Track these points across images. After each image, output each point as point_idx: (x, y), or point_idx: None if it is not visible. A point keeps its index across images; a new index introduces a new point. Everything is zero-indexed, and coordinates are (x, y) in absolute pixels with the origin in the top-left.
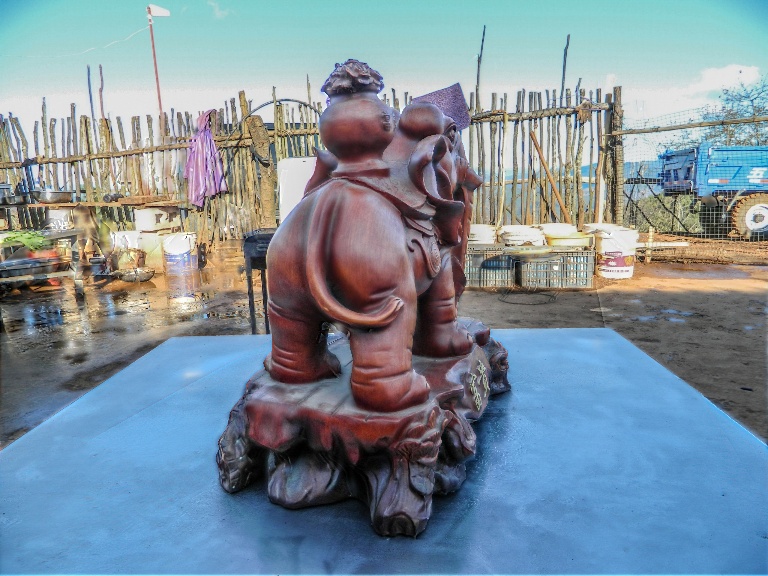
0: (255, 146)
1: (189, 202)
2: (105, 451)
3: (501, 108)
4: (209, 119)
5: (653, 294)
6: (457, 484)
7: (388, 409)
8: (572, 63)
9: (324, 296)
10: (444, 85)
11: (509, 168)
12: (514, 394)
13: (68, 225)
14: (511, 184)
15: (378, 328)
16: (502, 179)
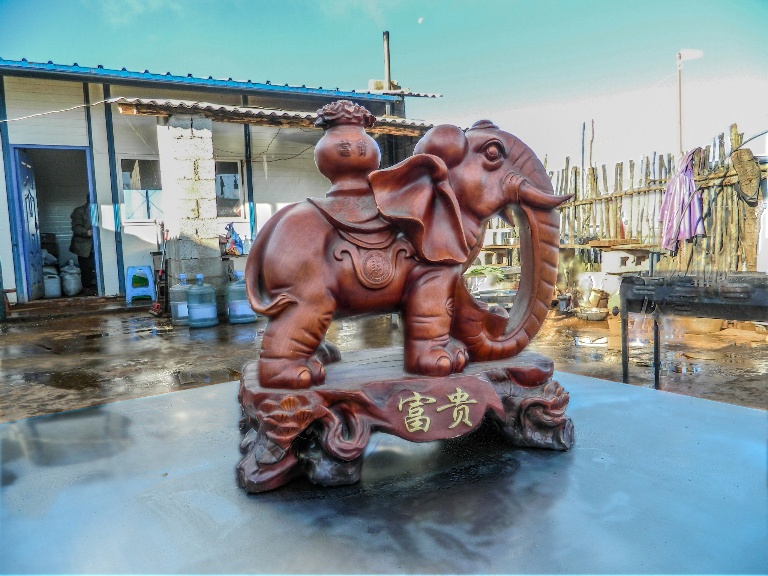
0: (740, 183)
1: (662, 246)
2: None
3: None
4: (692, 158)
5: None
6: (327, 479)
7: (263, 384)
8: None
9: (248, 287)
10: None
11: None
12: (559, 455)
13: None
14: None
15: (267, 317)
16: None
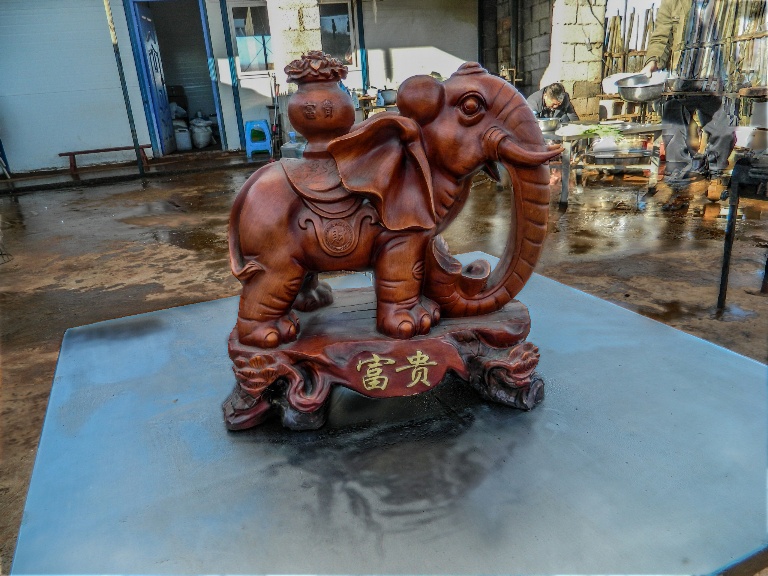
0: None
1: None
2: None
3: None
4: None
5: None
6: (292, 425)
7: None
8: None
9: (230, 247)
10: None
11: None
12: (518, 415)
13: (655, 119)
14: None
15: None
16: None
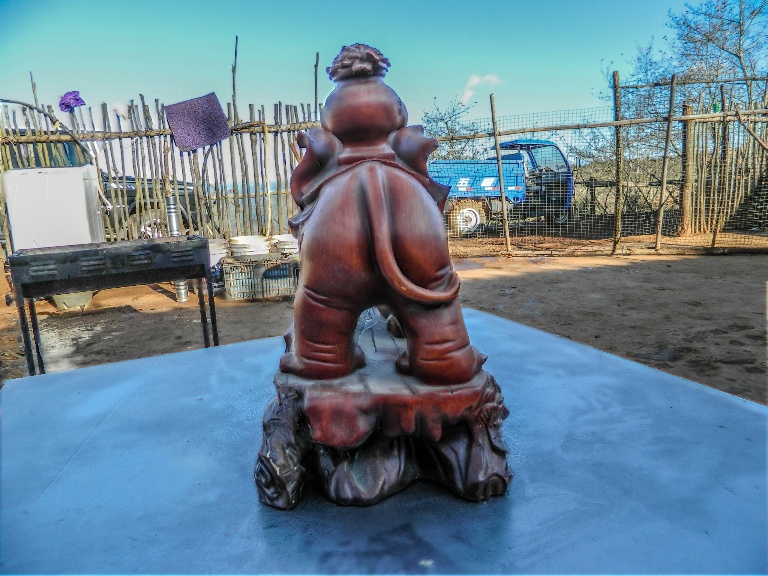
0: None
1: None
2: (71, 513)
3: (260, 119)
4: None
5: None
6: None
7: (464, 380)
8: (323, 80)
9: (400, 275)
10: (199, 94)
11: (273, 179)
12: None
13: None
14: (276, 195)
15: (448, 302)
16: (267, 190)
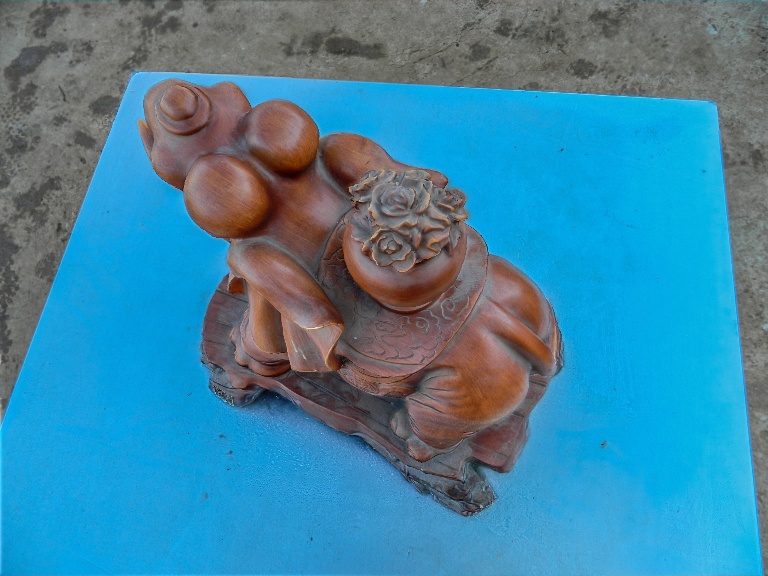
0: None
1: None
2: None
3: None
4: None
5: None
6: None
7: None
8: None
9: None
10: None
11: None
12: None
13: None
14: None
15: None
16: None
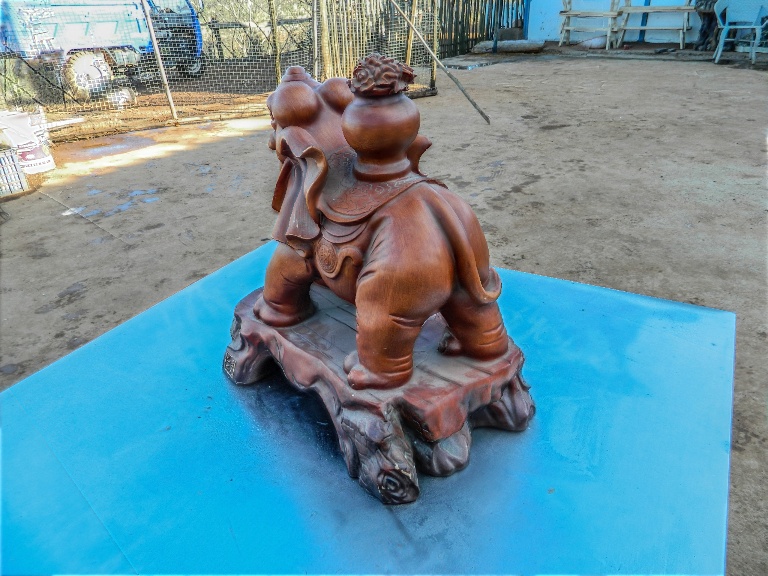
0: None
1: None
2: None
3: None
4: None
5: (100, 180)
6: None
7: None
8: None
9: (483, 289)
10: None
11: None
12: None
13: None
14: None
15: None
16: None
